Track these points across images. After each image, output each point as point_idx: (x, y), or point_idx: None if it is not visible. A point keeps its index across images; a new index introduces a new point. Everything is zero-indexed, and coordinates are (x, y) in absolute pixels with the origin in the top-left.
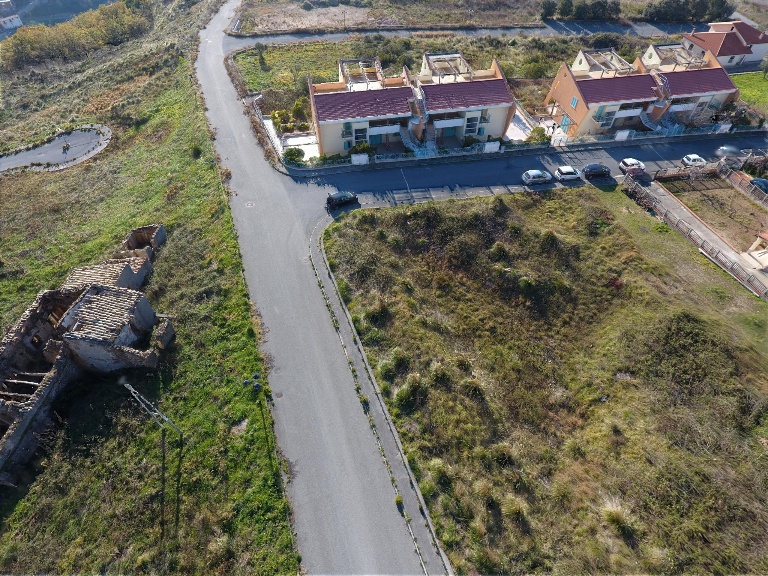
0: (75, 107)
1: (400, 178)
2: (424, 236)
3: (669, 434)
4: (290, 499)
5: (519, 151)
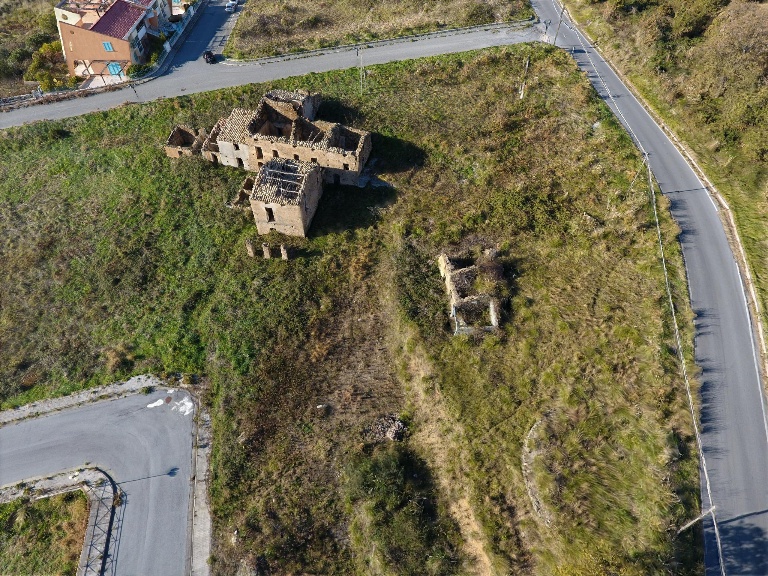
0: None
1: (196, 42)
2: (260, 40)
3: (401, 0)
4: None
5: (199, 8)
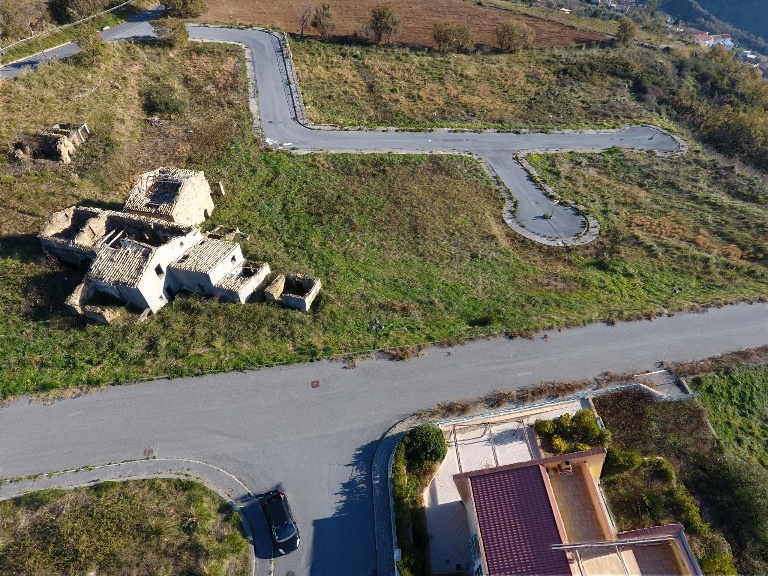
0: (647, 209)
1: None
2: None
3: None
4: None
5: None
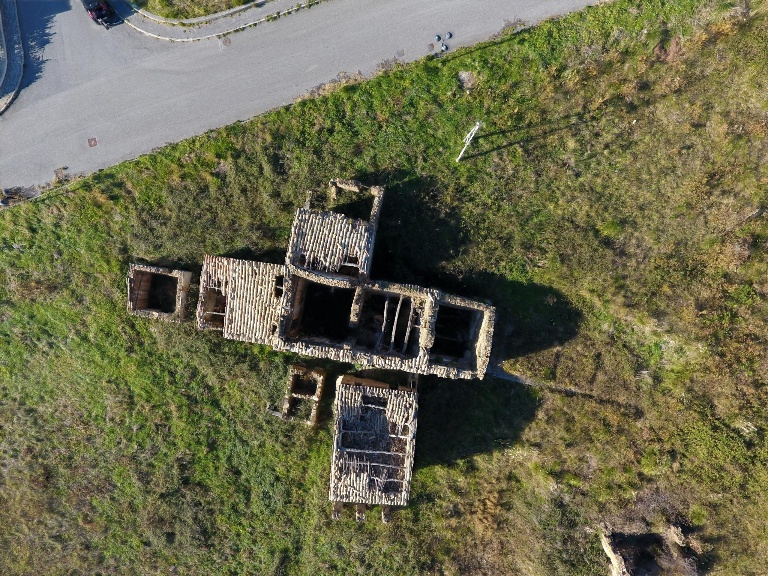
0: None
1: None
2: None
3: None
4: (540, 21)
5: None
